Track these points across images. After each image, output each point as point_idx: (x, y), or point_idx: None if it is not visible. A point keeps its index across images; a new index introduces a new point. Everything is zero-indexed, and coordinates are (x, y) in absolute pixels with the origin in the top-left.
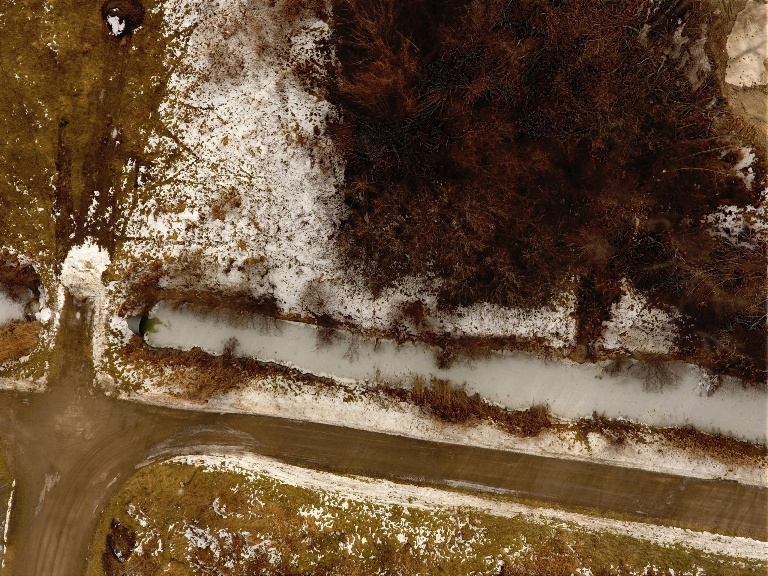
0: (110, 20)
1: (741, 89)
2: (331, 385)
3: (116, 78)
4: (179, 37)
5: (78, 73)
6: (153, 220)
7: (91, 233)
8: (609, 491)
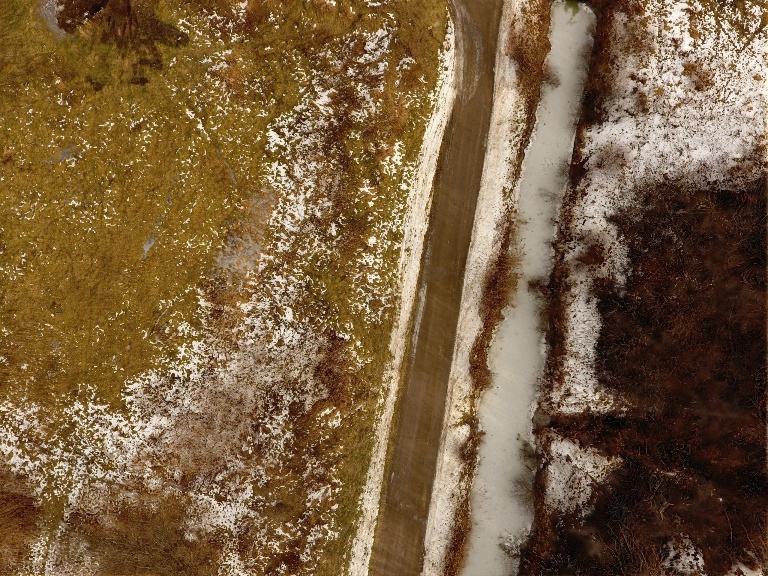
0: None
1: None
2: (516, 176)
3: None
4: None
5: None
6: (682, 8)
7: None
8: (414, 445)
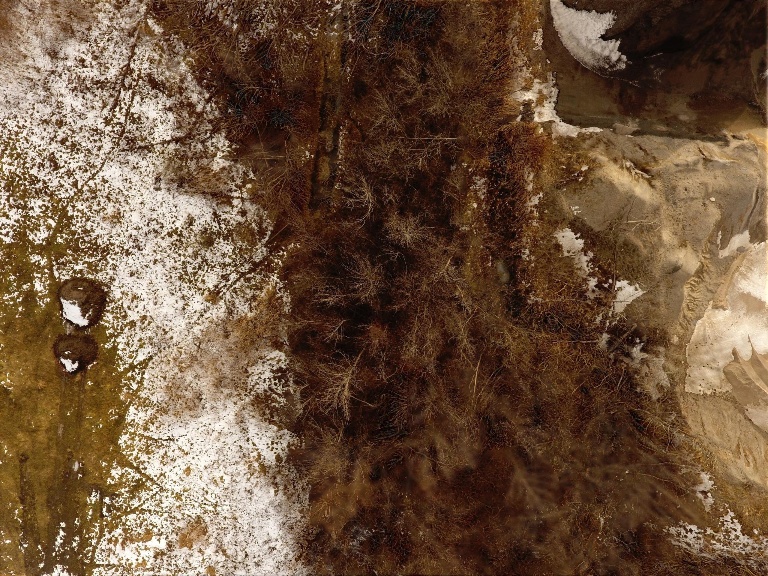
0: (63, 361)
1: (701, 397)
2: None
3: (73, 413)
4: (134, 370)
5: (35, 409)
6: (121, 550)
7: (60, 562)
8: None
